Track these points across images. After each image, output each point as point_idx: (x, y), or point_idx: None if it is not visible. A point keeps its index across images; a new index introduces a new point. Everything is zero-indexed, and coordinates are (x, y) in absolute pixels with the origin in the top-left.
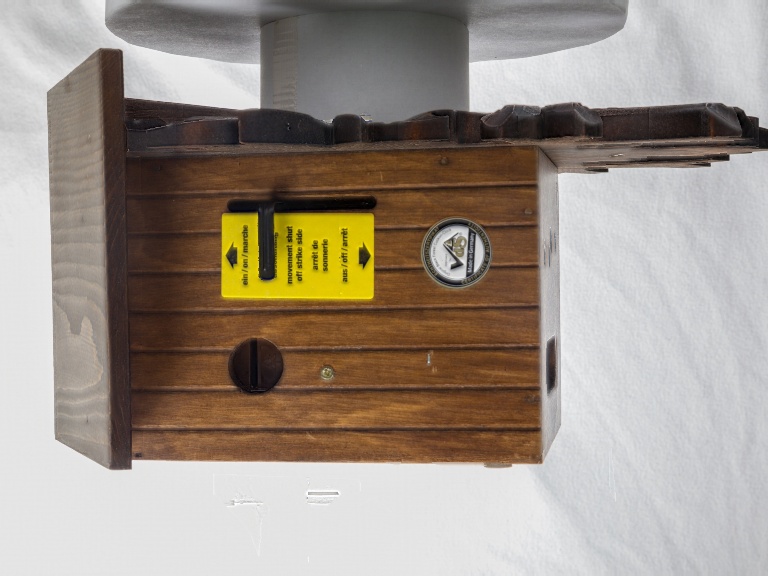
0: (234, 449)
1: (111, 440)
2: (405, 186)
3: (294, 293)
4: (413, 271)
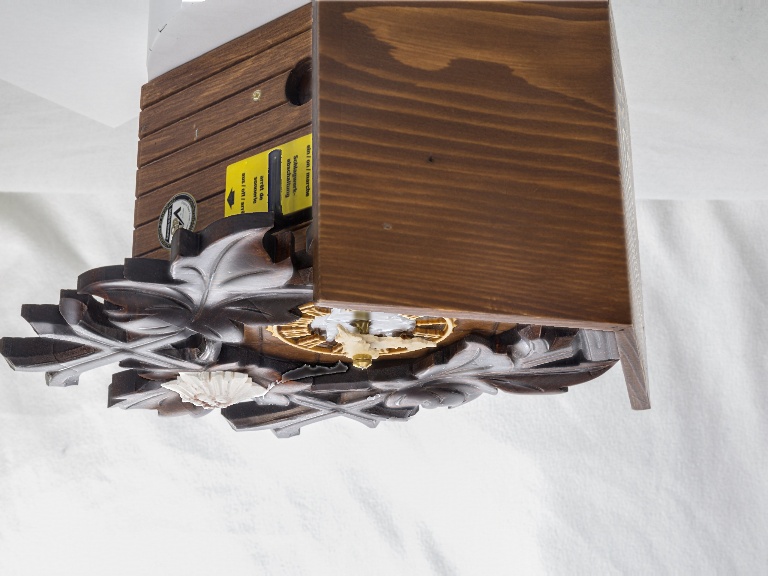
0: None
1: None
2: None
3: None
4: (203, 199)
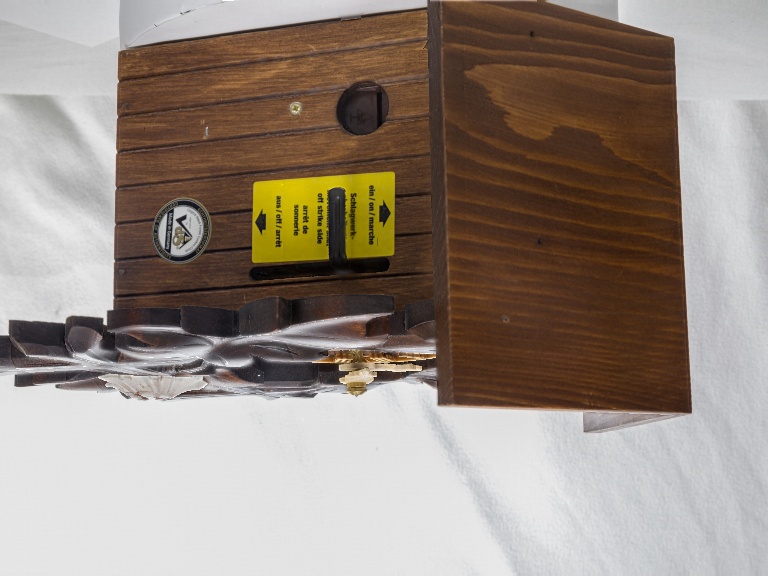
0: (384, 27)
1: (440, 3)
2: (225, 292)
3: (325, 183)
4: (219, 212)
